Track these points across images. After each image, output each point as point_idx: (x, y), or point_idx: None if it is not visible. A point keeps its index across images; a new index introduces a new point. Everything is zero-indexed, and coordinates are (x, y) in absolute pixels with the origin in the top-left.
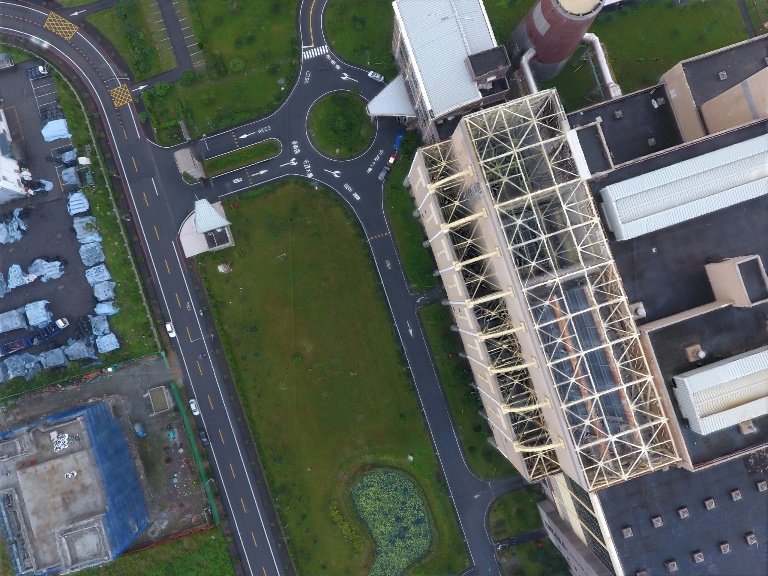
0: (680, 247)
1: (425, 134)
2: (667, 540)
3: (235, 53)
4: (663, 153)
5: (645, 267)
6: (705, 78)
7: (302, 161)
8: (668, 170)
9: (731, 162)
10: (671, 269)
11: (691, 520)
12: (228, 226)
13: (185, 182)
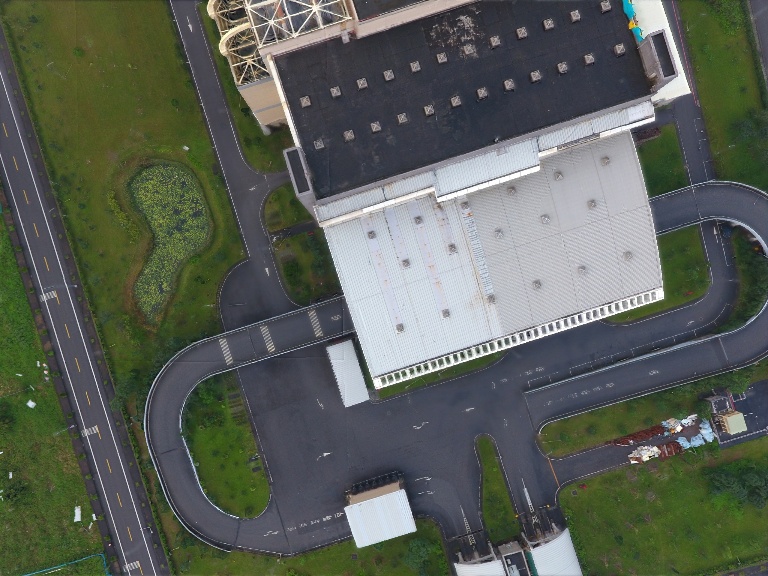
0: None
1: None
2: (346, 111)
3: None
4: None
5: None
6: None
7: None
8: None
9: None
10: None
11: (371, 92)
12: None
13: None
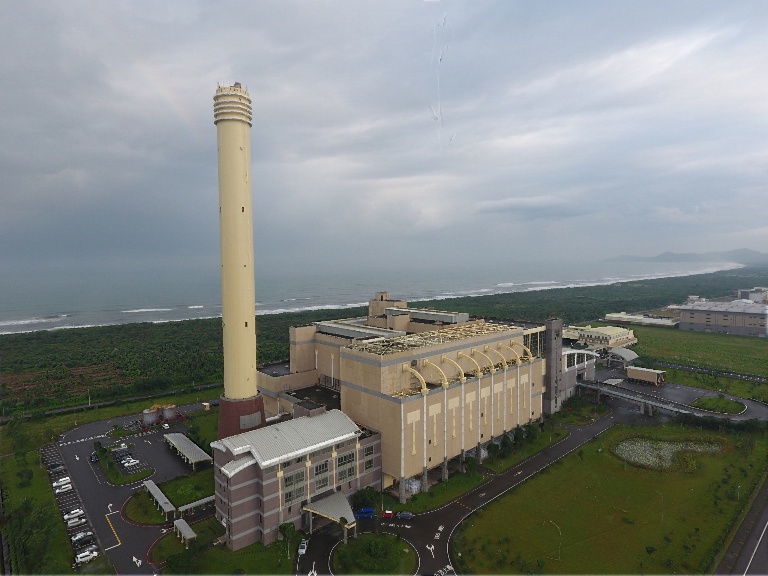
0: None
1: (358, 478)
2: None
3: None
4: None
5: None
6: None
7: None
8: None
9: None
10: None
11: None
12: None
13: None
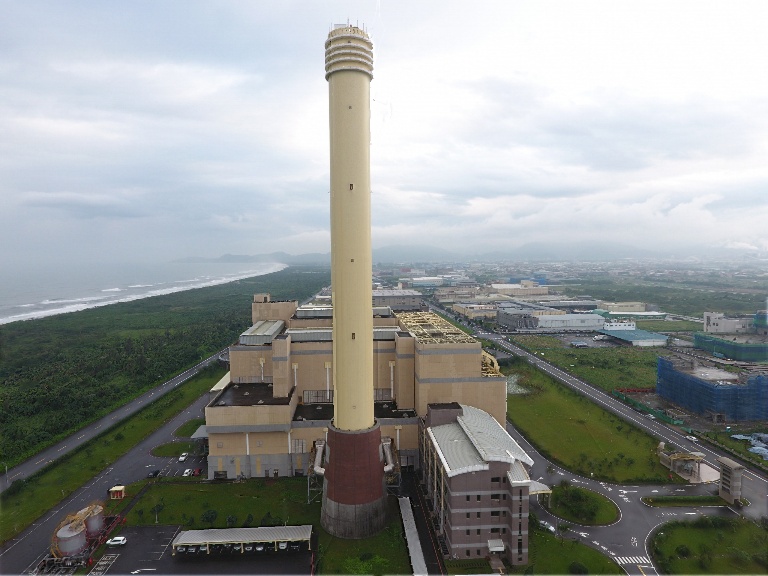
0: None
1: None
2: None
3: None
4: None
5: None
6: None
7: None
8: None
9: None
10: None
11: None
12: None
13: (741, 497)
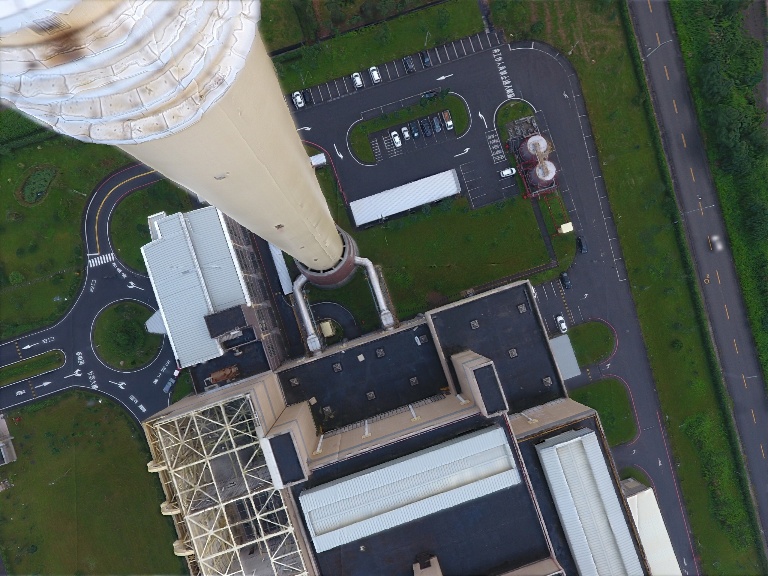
0: (389, 545)
1: None
2: None
3: (18, 262)
4: (368, 451)
5: (352, 566)
6: (457, 327)
7: (86, 373)
8: (363, 479)
9: (428, 470)
10: (379, 568)
11: None
12: (8, 442)
13: None
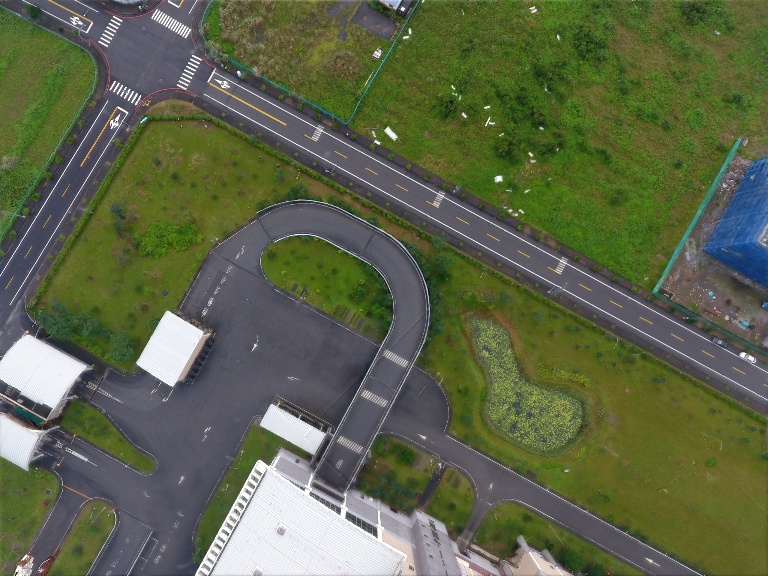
0: None
1: None
2: None
3: None
4: None
5: None
6: None
7: None
8: None
9: None
10: None
11: None
12: None
13: None
